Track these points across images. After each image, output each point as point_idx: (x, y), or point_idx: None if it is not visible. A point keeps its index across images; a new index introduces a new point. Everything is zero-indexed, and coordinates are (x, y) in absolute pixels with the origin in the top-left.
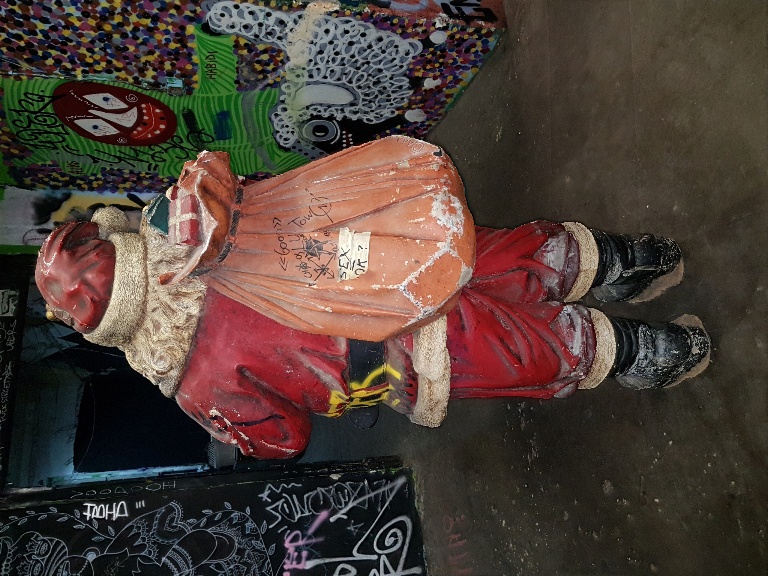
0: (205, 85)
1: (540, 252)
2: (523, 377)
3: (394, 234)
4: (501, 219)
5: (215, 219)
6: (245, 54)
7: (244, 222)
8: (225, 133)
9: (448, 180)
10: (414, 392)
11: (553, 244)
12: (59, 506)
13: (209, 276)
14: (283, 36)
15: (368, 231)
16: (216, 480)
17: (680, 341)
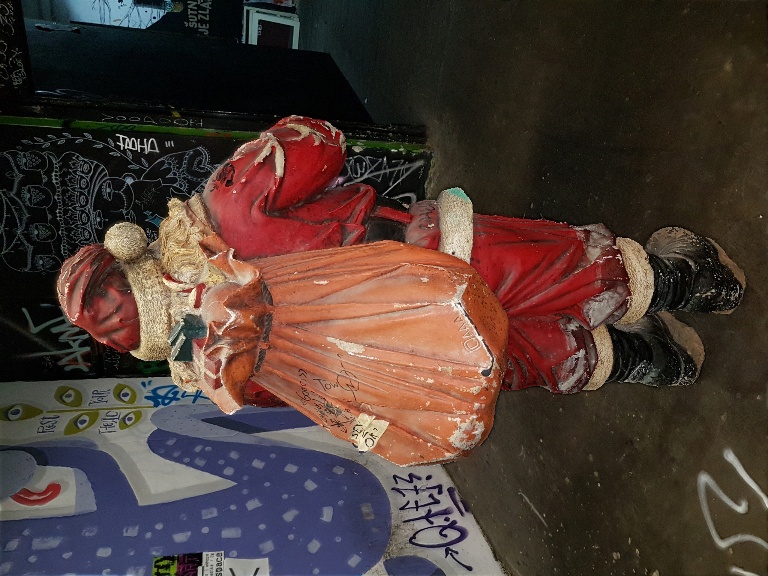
0: None
1: (587, 299)
2: None
3: (410, 429)
4: (636, 6)
5: (239, 405)
6: None
7: (270, 357)
8: None
9: (483, 404)
10: None
11: (605, 296)
12: (93, 133)
13: None
14: None
15: (388, 417)
16: (242, 126)
17: (666, 382)
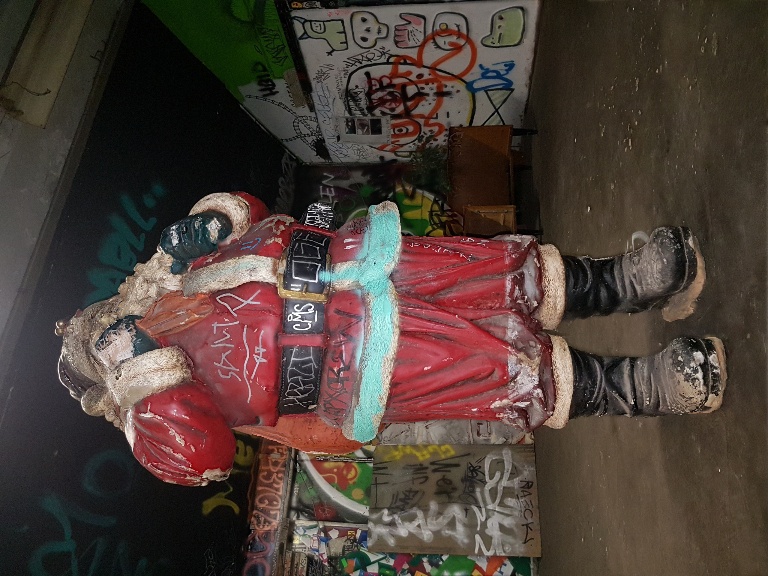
0: None
1: None
2: None
3: None
4: None
5: None
6: None
7: None
8: None
9: None
10: None
11: None
12: None
13: None
14: None
15: None
16: None
17: None
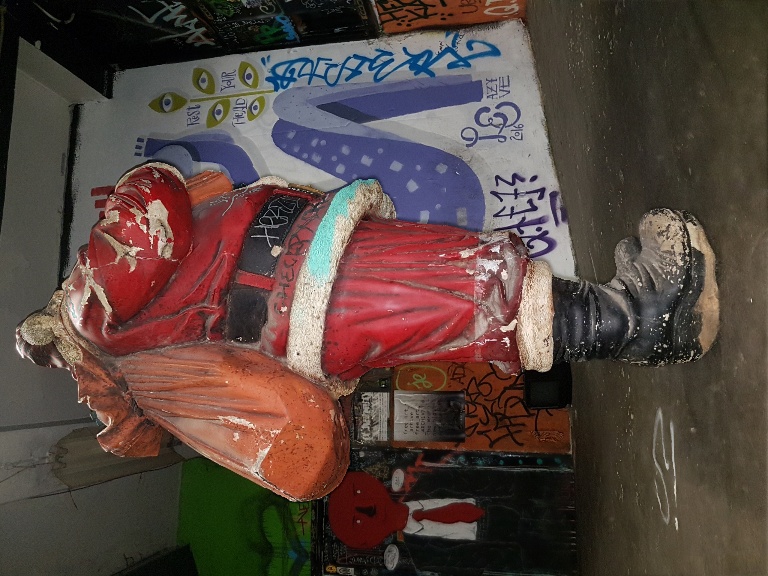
0: None
1: None
2: None
3: None
4: None
5: None
6: None
7: None
8: None
9: None
10: None
11: None
12: None
13: None
14: None
15: None
16: None
17: None
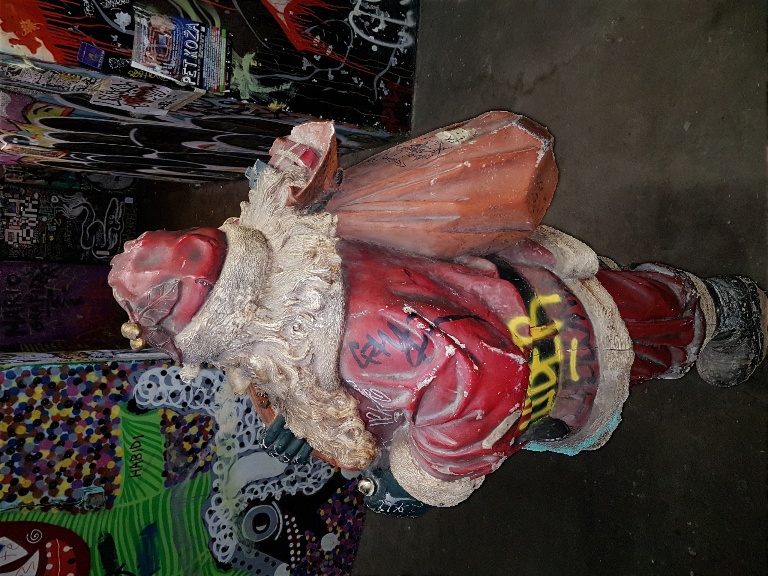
0: (128, 488)
1: None
2: (656, 298)
3: None
4: None
5: None
6: (173, 432)
7: None
8: (151, 563)
9: None
10: (583, 314)
11: None
12: None
13: (329, 211)
14: (210, 399)
15: None
16: None
17: None
